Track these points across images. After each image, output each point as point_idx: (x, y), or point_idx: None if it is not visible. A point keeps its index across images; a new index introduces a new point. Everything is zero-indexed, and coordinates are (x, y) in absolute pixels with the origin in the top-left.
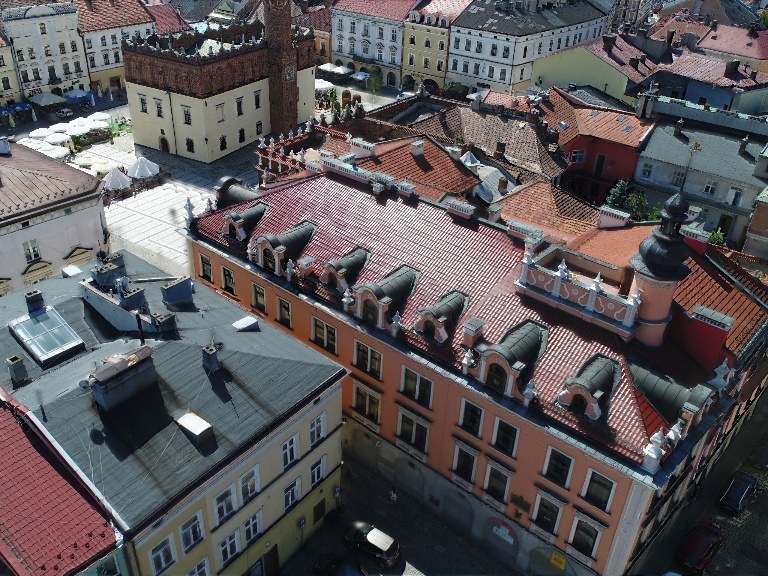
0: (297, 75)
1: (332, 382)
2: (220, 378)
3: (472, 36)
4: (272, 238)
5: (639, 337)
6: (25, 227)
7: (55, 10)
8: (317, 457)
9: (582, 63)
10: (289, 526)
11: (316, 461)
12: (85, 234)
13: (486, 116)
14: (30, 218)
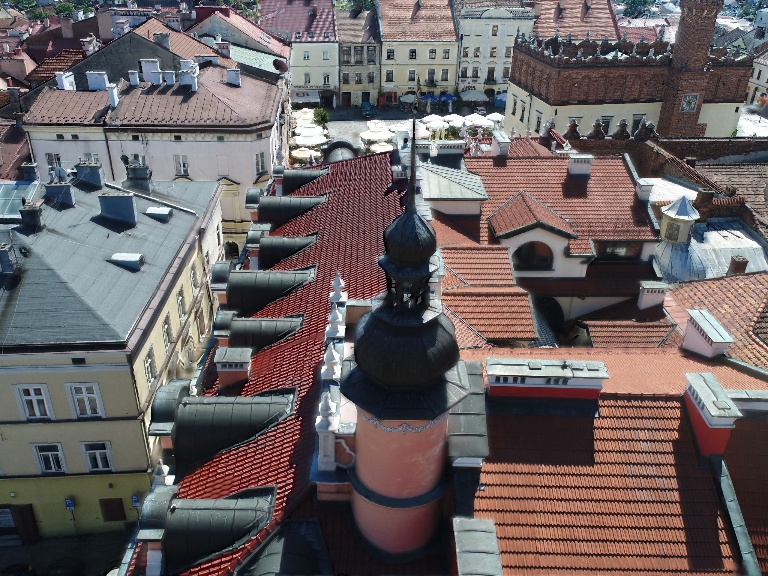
0: (709, 108)
1: (96, 347)
2: (4, 282)
3: None
4: (253, 192)
5: (353, 507)
6: (177, 140)
7: (513, 15)
8: (93, 436)
9: None
10: (55, 496)
11: (93, 440)
12: (235, 167)
13: None
14: (180, 132)
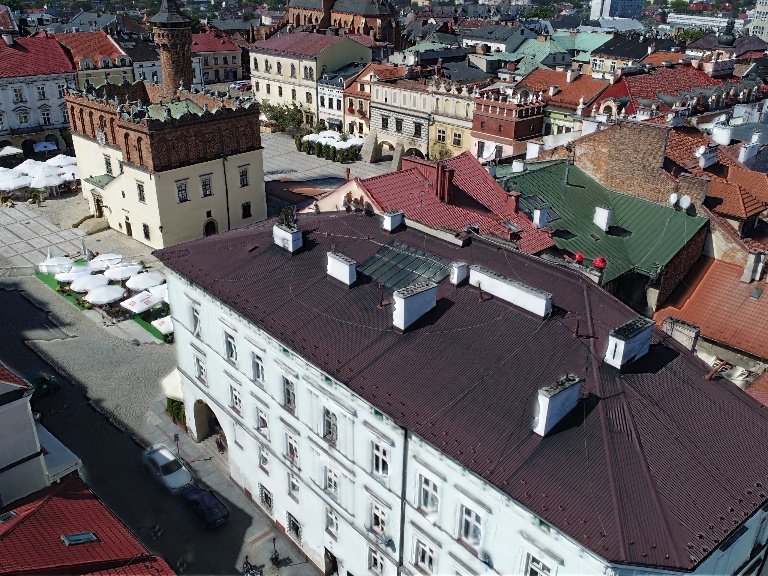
0: None
1: None
2: None
3: (157, 67)
4: None
5: None
6: None
7: None
8: None
9: (346, 48)
10: None
11: None
12: None
13: (419, 80)
14: None
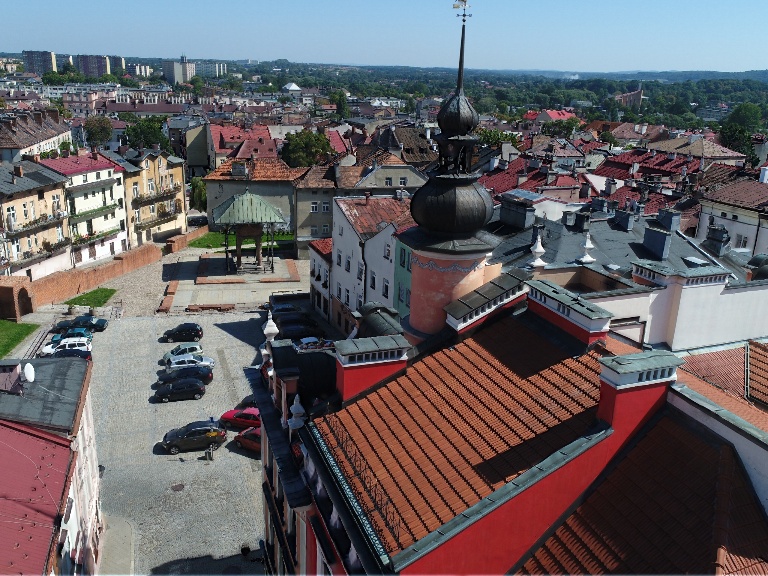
0: None
1: None
2: (527, 248)
3: None
4: (762, 257)
5: None
6: None
7: None
8: None
9: None
10: None
11: None
12: None
13: None
14: None
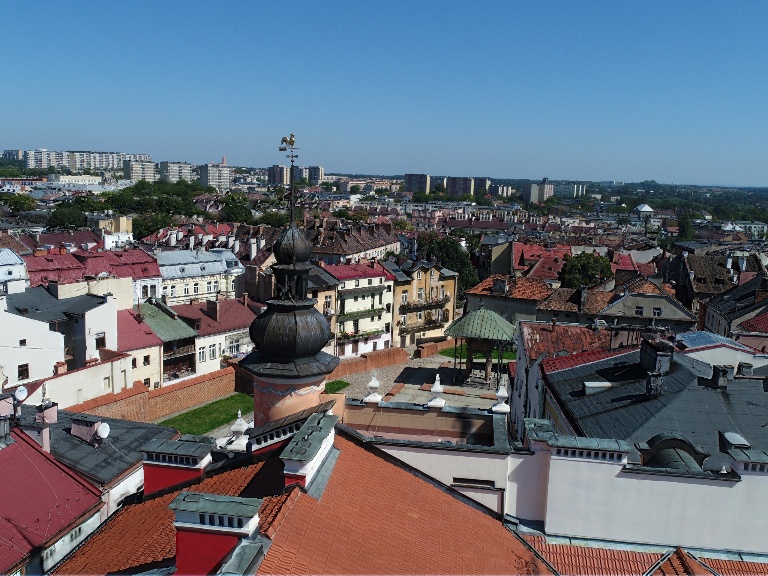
0: None
1: None
2: None
3: None
4: None
5: None
6: None
7: None
8: None
9: None
10: None
11: None
12: None
13: None
14: None
